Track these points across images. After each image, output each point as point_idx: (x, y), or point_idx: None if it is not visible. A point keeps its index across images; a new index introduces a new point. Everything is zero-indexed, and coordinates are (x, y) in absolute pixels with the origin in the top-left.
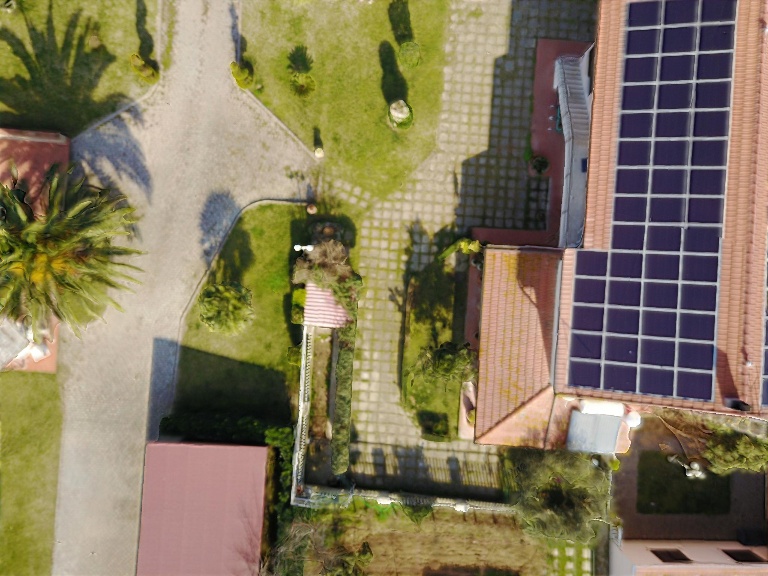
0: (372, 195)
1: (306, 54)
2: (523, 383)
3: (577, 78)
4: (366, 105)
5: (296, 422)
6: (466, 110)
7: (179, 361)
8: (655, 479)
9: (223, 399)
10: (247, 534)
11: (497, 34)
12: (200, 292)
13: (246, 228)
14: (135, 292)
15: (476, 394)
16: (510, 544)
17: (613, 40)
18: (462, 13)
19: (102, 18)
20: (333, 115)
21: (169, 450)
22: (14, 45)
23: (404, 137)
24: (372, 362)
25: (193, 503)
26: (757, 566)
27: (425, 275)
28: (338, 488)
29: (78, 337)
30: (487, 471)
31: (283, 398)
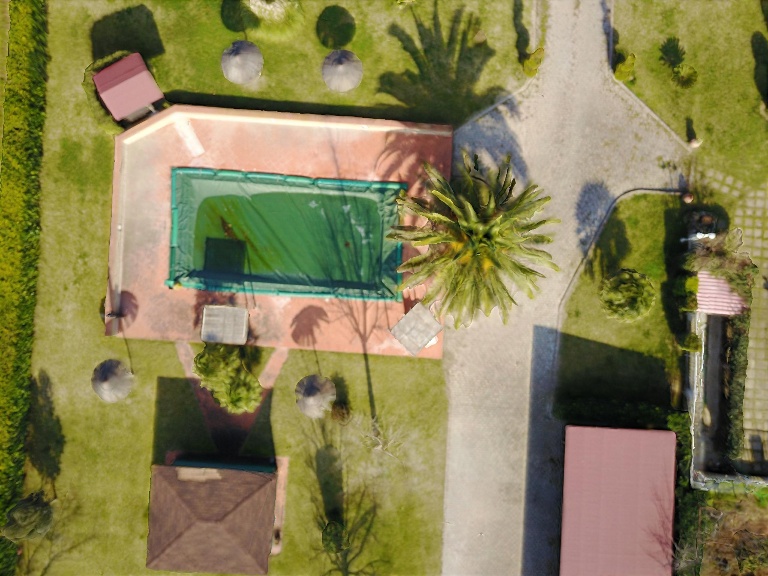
0: (744, 184)
1: (678, 46)
2: None
3: None
4: (739, 95)
5: (682, 408)
6: None
7: (559, 347)
8: None
9: (602, 385)
10: (659, 516)
11: None
12: (578, 280)
13: (621, 217)
14: None
15: None
16: None
17: None
18: None
19: (483, 13)
20: (706, 105)
21: (586, 433)
22: (404, 40)
23: None
24: (747, 349)
25: (608, 485)
26: None
27: None
28: (721, 473)
29: (504, 322)
30: None
31: (663, 384)
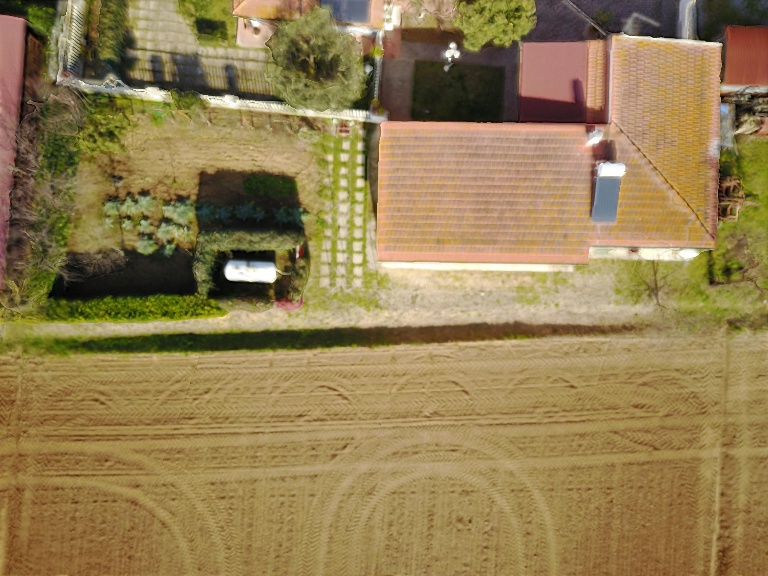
0: None
1: None
2: None
3: None
4: None
5: None
6: None
7: None
8: (431, 89)
9: (1, 1)
10: (6, 102)
11: None
12: None
13: None
14: None
15: None
16: (287, 151)
17: None
18: None
19: None
20: None
21: None
22: None
23: None
24: None
25: None
26: (500, 123)
27: None
28: None
29: None
30: None
31: (61, 0)
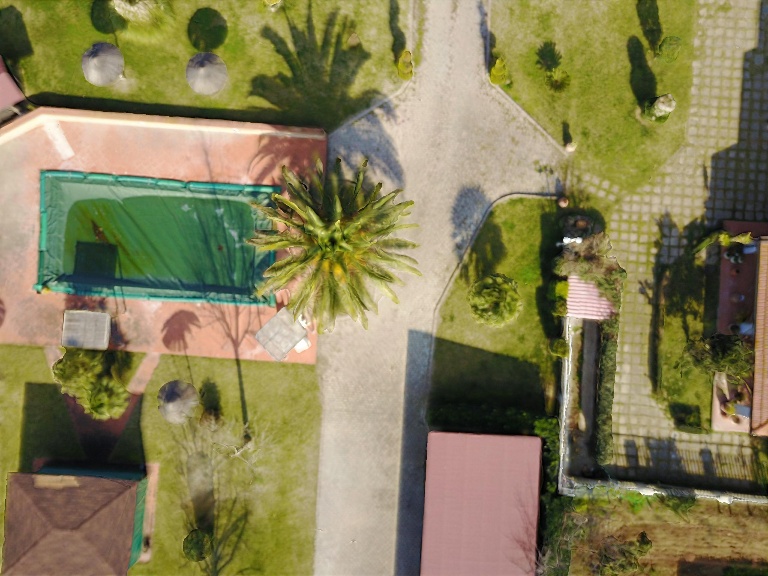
0: (621, 189)
1: (555, 50)
2: None
3: None
4: (615, 100)
5: (554, 413)
6: (715, 104)
7: (434, 352)
8: None
9: (477, 390)
10: (523, 523)
11: (746, 28)
12: (453, 284)
13: (497, 221)
14: (405, 284)
15: (752, 385)
16: (766, 537)
17: None
18: (711, 8)
19: (358, 16)
20: (582, 110)
21: (449, 439)
22: (277, 43)
23: (653, 131)
24: (623, 354)
25: (471, 491)
26: None
27: (675, 268)
28: (594, 479)
29: (364, 327)
30: (741, 463)
31: (537, 389)
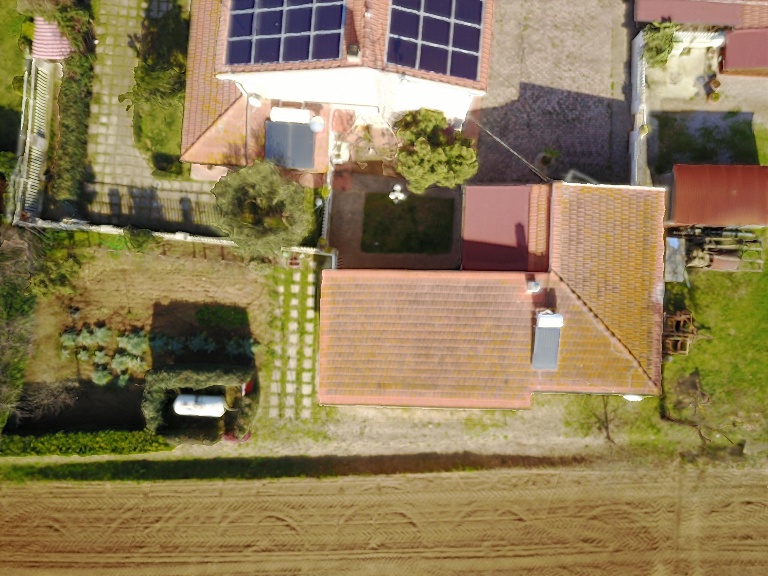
0: None
1: None
2: (221, 97)
3: None
4: None
5: None
6: None
7: None
8: (381, 221)
9: None
10: None
11: None
12: None
13: None
14: None
15: None
16: (238, 282)
17: None
18: None
19: None
20: None
21: None
22: None
23: None
24: (111, 106)
25: None
26: (439, 272)
27: (163, 22)
28: None
29: None
30: (218, 212)
31: (22, 137)
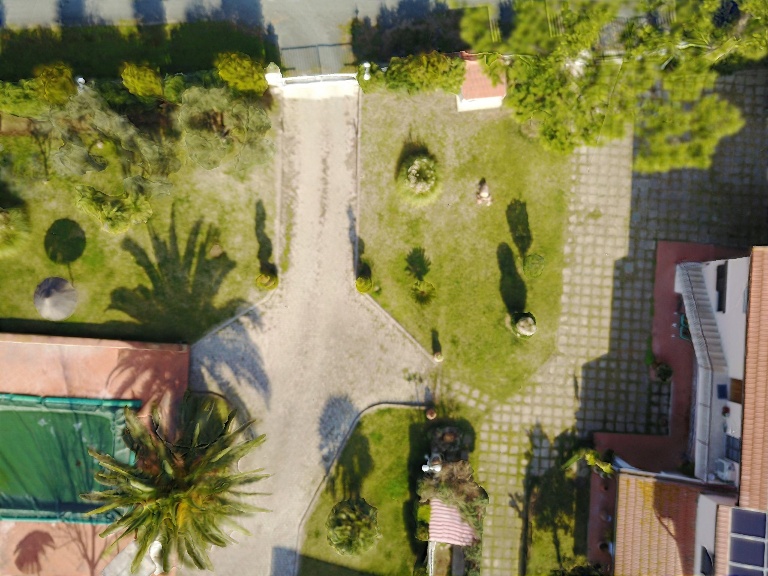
0: (491, 398)
1: (424, 256)
2: None
3: (701, 286)
4: (484, 307)
5: None
6: (585, 312)
7: (298, 571)
8: None
9: None
10: None
11: (616, 236)
12: (319, 499)
13: (364, 433)
14: None
15: None
16: None
17: (766, 295)
18: (580, 215)
19: (222, 224)
20: (451, 317)
21: None
22: (137, 255)
23: (523, 340)
24: (492, 570)
25: None
26: None
27: (545, 480)
28: None
29: None
30: None
31: None
